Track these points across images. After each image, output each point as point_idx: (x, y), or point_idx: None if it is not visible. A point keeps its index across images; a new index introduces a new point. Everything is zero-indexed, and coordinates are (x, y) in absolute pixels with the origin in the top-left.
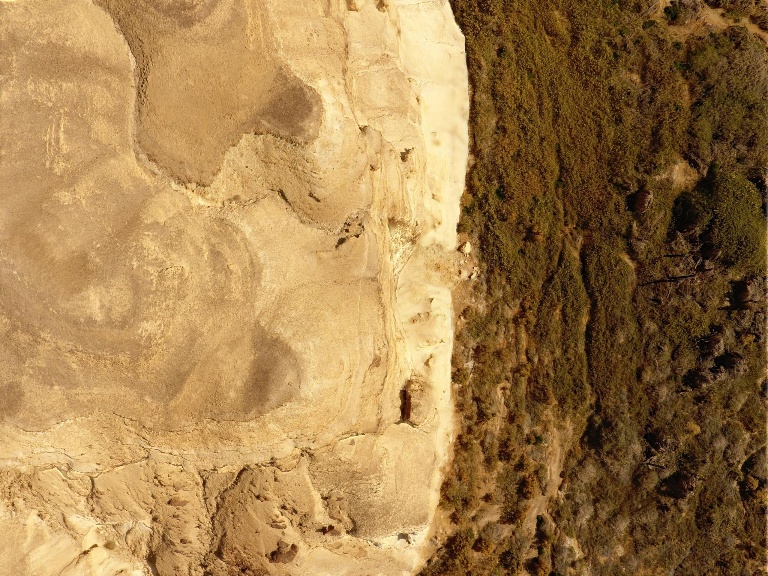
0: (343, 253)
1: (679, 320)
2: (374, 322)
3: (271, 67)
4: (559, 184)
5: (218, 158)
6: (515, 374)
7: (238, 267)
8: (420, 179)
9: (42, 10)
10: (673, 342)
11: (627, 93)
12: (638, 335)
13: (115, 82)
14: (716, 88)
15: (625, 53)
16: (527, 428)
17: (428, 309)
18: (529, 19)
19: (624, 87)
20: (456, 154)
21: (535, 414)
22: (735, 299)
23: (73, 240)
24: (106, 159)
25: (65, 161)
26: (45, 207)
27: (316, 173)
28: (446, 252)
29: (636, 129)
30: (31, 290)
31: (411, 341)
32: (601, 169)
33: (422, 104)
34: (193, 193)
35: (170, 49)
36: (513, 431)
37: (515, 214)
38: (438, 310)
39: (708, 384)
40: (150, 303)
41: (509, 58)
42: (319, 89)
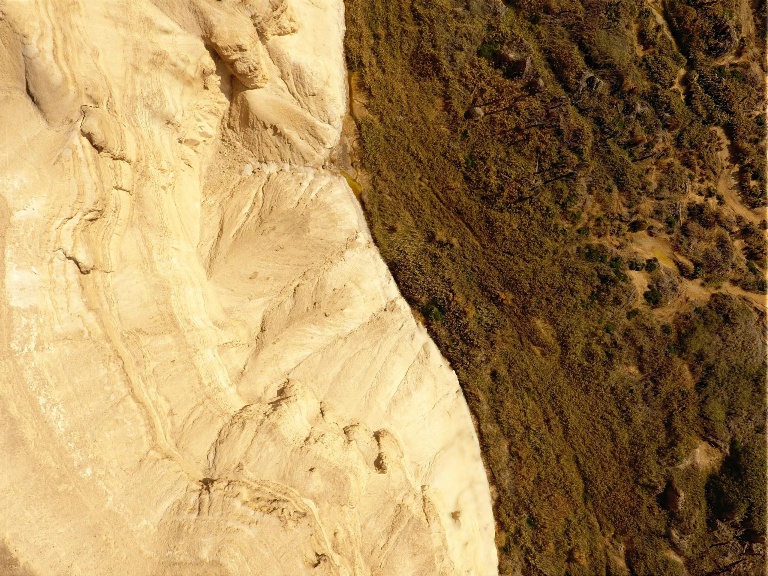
0: None
1: None
2: None
3: None
4: (586, 496)
5: None
6: None
7: None
8: None
9: None
10: None
11: (630, 391)
12: None
13: None
14: (716, 367)
15: (617, 350)
16: None
17: None
18: (514, 338)
19: (625, 384)
20: (479, 501)
21: None
22: None
23: None
24: None
25: None
26: None
27: None
28: None
29: (648, 425)
30: None
31: None
32: (624, 472)
33: (439, 503)
34: None
35: None
36: None
37: (552, 541)
38: None
39: None
40: None
41: (504, 382)
42: None
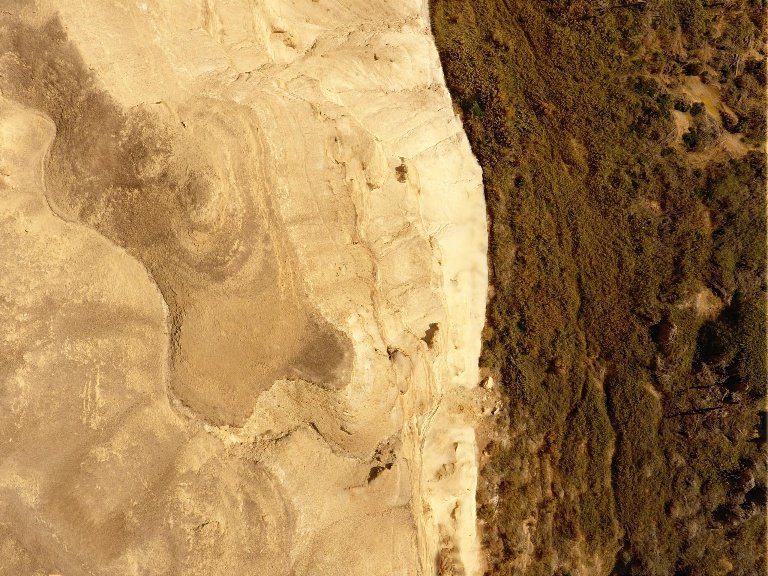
0: (376, 488)
1: (707, 455)
2: (408, 552)
3: (302, 315)
4: (580, 314)
5: (251, 402)
6: (541, 510)
7: (273, 517)
8: (444, 348)
9: (78, 267)
10: (702, 477)
11: (647, 222)
12: (665, 469)
13: (149, 332)
14: (738, 217)
15: (644, 181)
16: (554, 565)
17: (453, 459)
18: (546, 149)
19: (644, 216)
20: (476, 289)
21: (562, 551)
22: (764, 431)
23: (111, 500)
24: (141, 408)
25: (101, 414)
26: (83, 465)
27: (348, 412)
28: (469, 390)
29: (657, 258)
30: (70, 554)
31: (437, 497)
32: (623, 299)
33: (443, 255)
34: (226, 432)
35: (203, 303)
36: (540, 569)
37: (537, 347)
38: (463, 459)
39: (739, 522)
40: (187, 565)
41: (527, 188)
42: (350, 331)
